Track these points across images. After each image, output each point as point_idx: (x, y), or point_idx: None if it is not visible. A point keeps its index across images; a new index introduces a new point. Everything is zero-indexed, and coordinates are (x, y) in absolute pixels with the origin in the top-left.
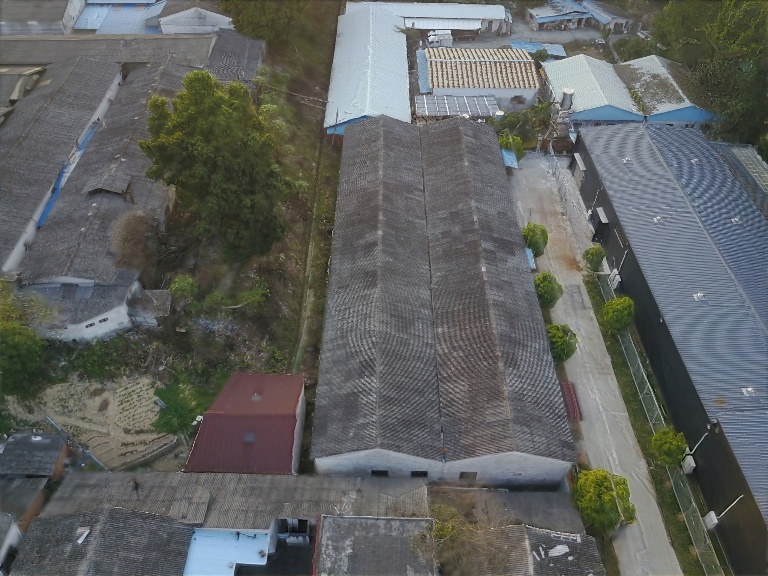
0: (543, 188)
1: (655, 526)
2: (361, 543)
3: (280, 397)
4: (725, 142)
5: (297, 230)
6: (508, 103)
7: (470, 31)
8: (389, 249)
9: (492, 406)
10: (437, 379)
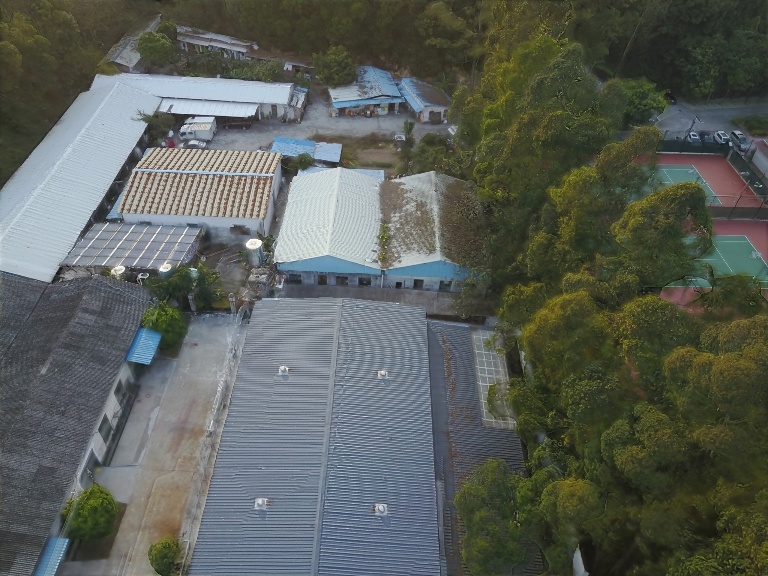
0: (206, 382)
1: None
2: None
3: None
4: None
5: None
6: (228, 233)
7: (242, 118)
8: None
9: None
10: None
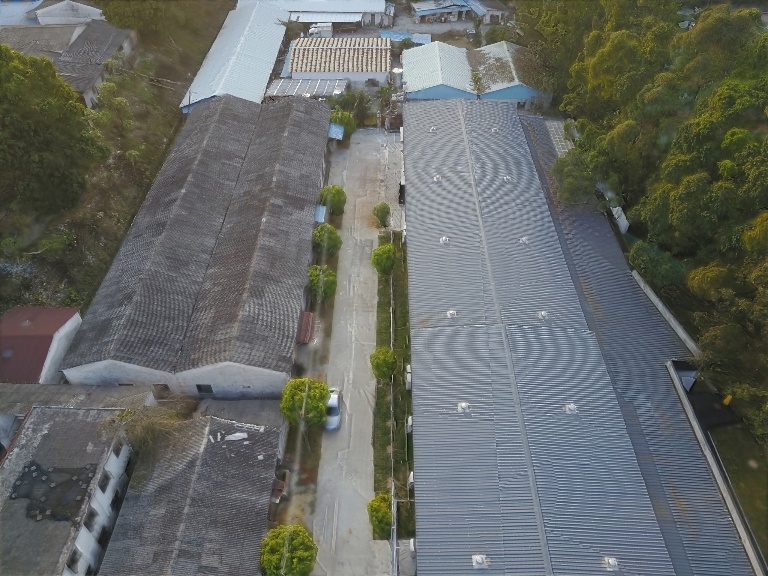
0: (372, 159)
1: (364, 431)
2: (57, 426)
3: (47, 323)
4: (544, 116)
5: (127, 194)
6: (363, 86)
7: (351, 24)
8: (187, 205)
9: (225, 327)
10: (193, 309)
